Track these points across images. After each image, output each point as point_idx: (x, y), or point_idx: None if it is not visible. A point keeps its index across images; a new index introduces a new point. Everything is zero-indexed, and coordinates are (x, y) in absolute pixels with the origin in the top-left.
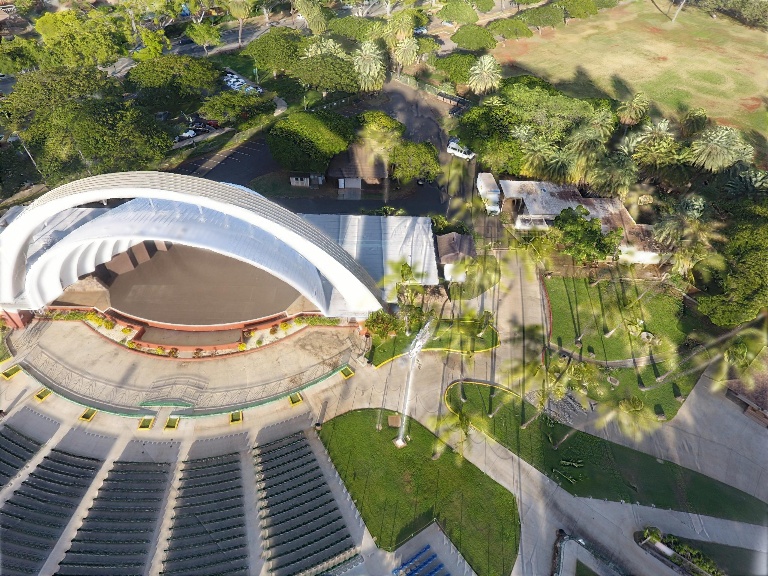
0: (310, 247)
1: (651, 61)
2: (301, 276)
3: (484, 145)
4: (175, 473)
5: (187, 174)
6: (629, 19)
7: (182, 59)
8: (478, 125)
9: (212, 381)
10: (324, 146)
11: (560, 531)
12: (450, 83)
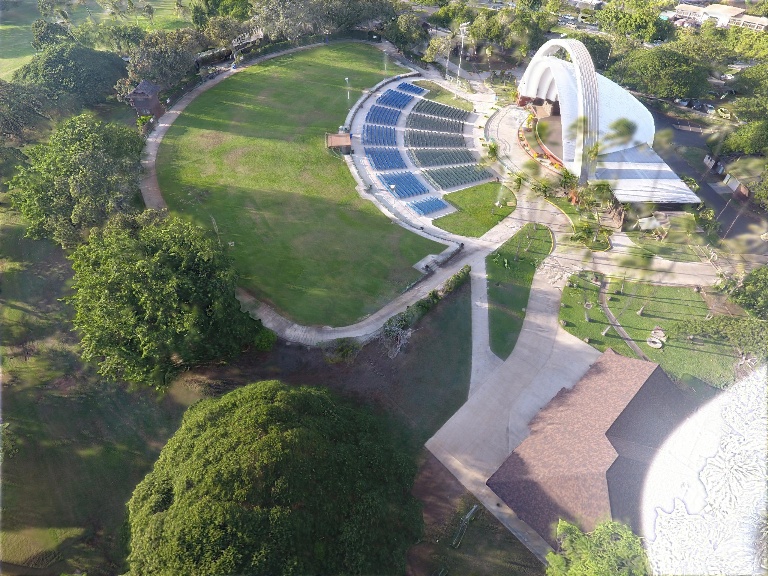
0: None
1: None
2: (572, 128)
3: None
4: None
5: (674, 123)
6: None
7: None
8: None
9: (511, 152)
10: (740, 140)
11: None
12: None
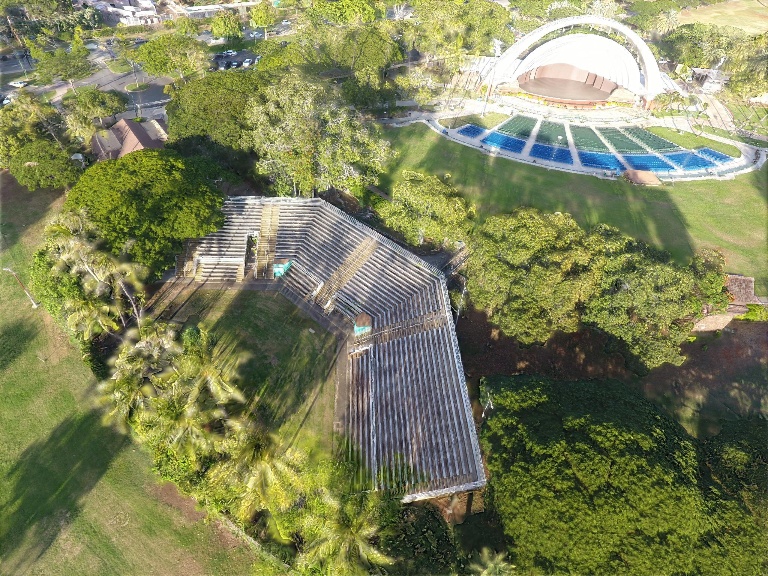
0: (649, 53)
1: (763, 31)
2: None
3: (681, 51)
4: None
5: None
6: (742, 9)
7: (493, 3)
8: (675, 42)
9: None
10: None
11: None
12: (639, 30)
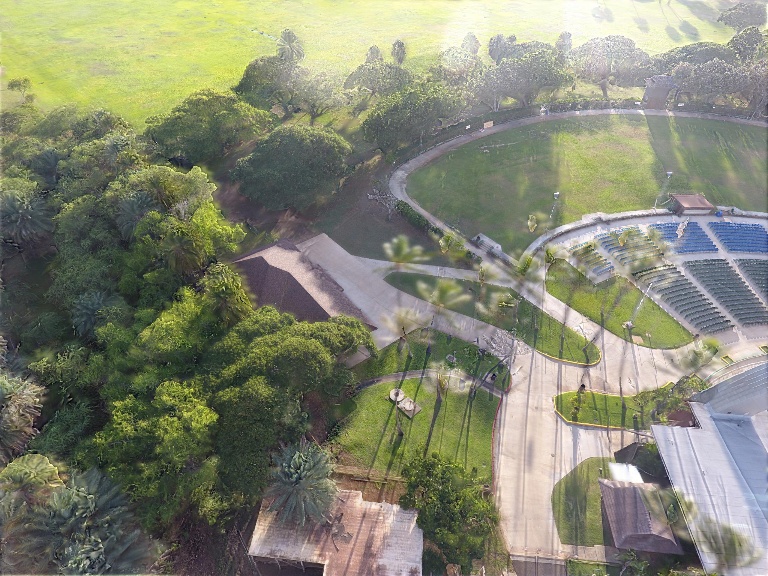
0: None
1: None
2: None
3: None
4: None
5: None
6: None
7: None
8: None
9: None
10: None
11: (525, 271)
12: None
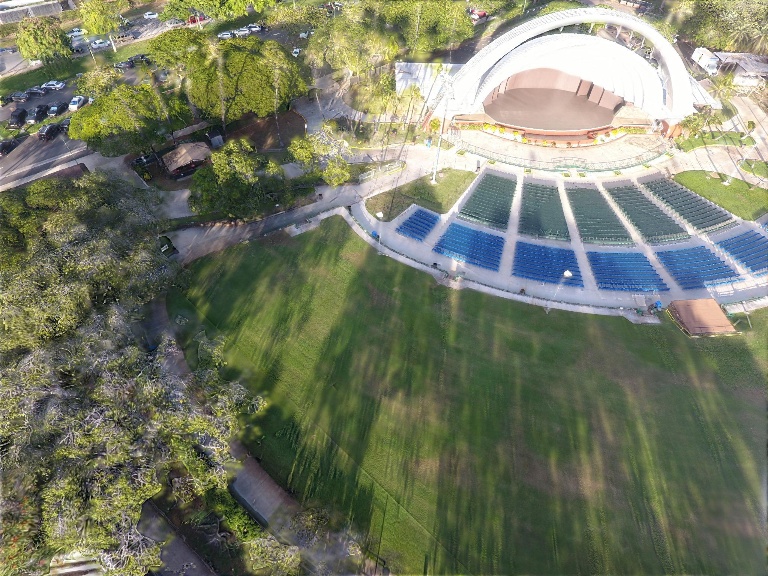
0: (677, 61)
1: None
2: None
3: (698, 27)
4: (603, 194)
5: (470, 52)
6: None
7: None
8: (689, 13)
9: (588, 158)
10: None
11: None
12: None
